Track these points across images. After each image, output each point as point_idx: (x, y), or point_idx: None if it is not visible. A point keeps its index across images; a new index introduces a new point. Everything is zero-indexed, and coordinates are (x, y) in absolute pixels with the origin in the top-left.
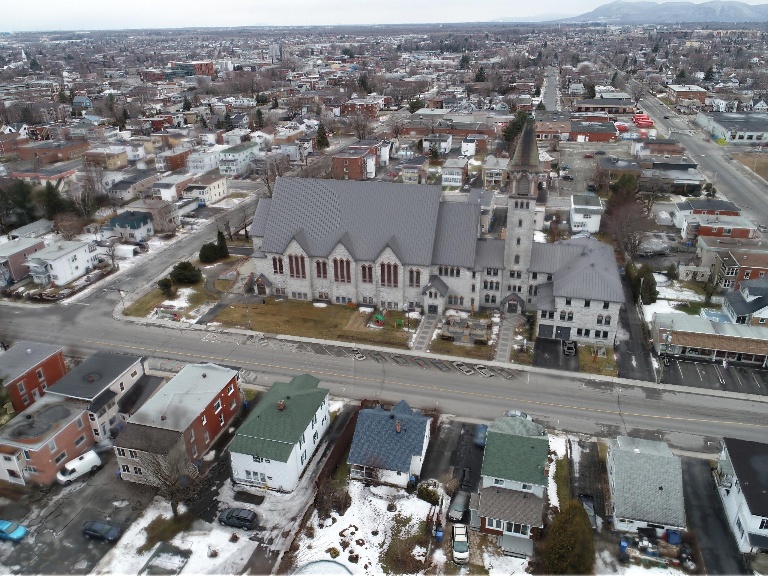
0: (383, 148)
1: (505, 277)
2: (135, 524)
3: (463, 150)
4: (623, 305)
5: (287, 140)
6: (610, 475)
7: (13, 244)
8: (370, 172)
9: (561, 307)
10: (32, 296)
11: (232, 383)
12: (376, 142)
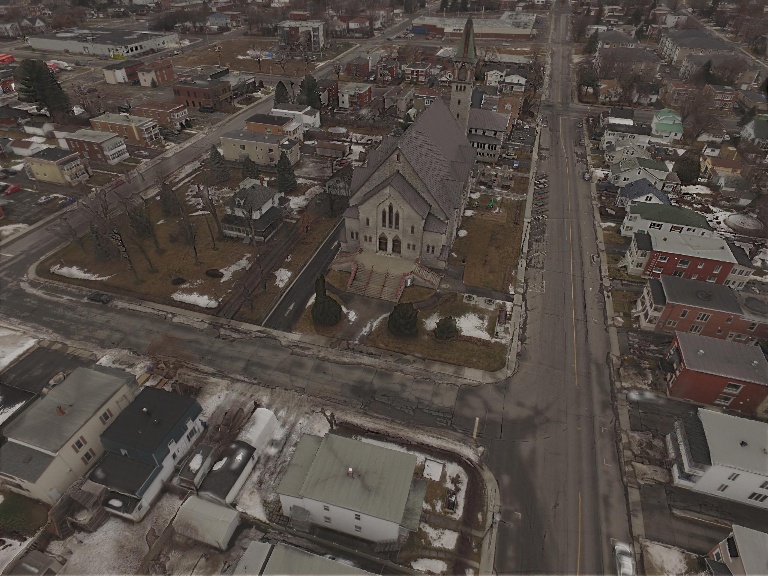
0: None
1: None
2: (764, 280)
3: None
4: None
5: None
6: None
7: None
8: None
9: None
10: (457, 521)
11: None
12: None
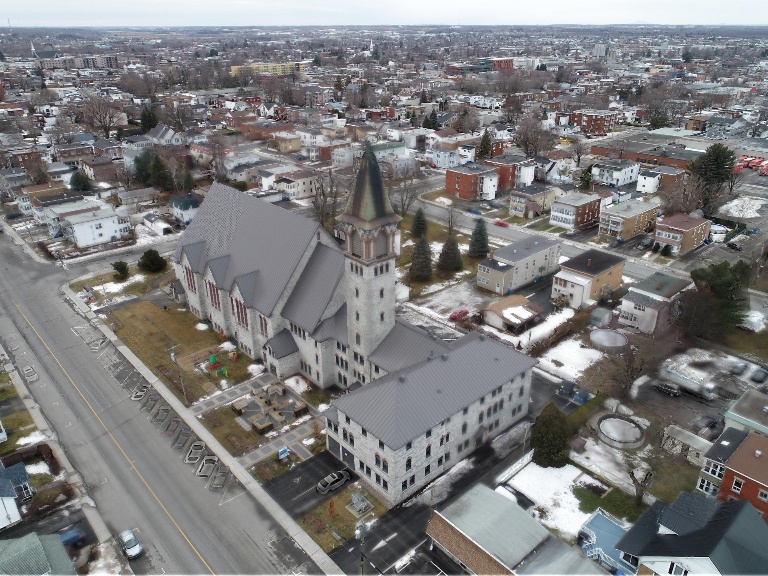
0: (523, 168)
1: (350, 358)
2: None
3: (638, 184)
4: (507, 452)
5: (455, 145)
6: None
7: (79, 204)
8: (486, 193)
9: (342, 422)
10: (51, 251)
11: None
12: (522, 160)
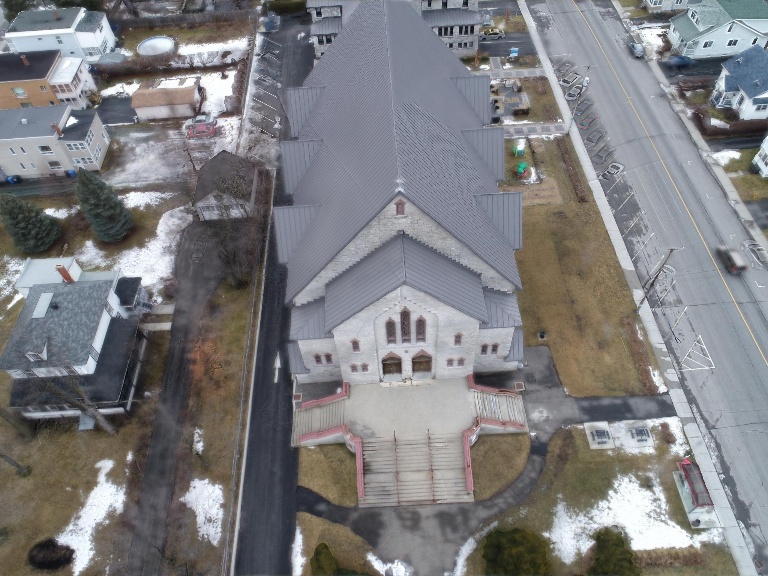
0: None
1: None
2: None
3: None
4: None
5: None
6: (678, 3)
7: None
8: None
9: None
10: None
11: None
12: None
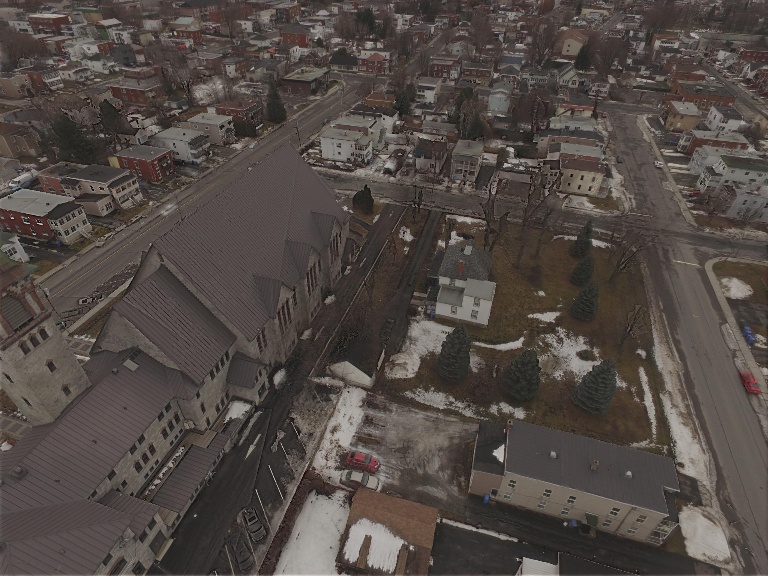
0: None
1: None
2: None
3: None
4: None
5: None
6: None
7: (362, 121)
8: None
9: None
10: None
11: (41, 220)
12: None
